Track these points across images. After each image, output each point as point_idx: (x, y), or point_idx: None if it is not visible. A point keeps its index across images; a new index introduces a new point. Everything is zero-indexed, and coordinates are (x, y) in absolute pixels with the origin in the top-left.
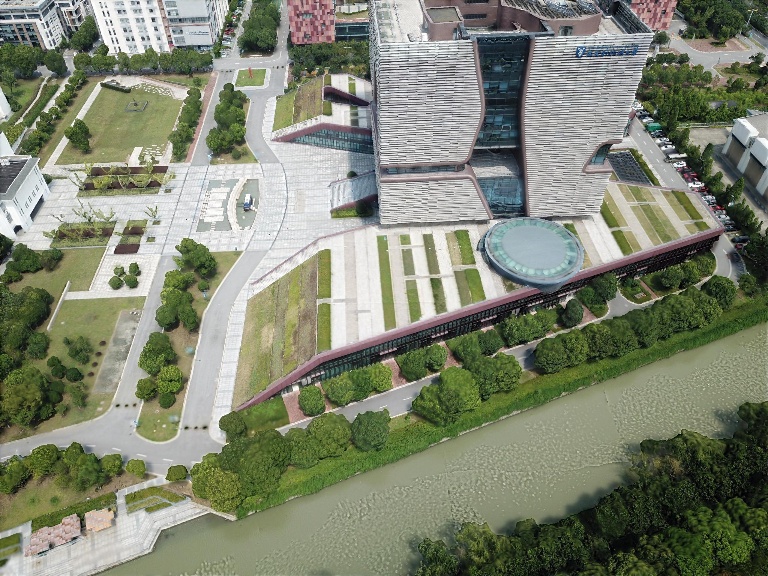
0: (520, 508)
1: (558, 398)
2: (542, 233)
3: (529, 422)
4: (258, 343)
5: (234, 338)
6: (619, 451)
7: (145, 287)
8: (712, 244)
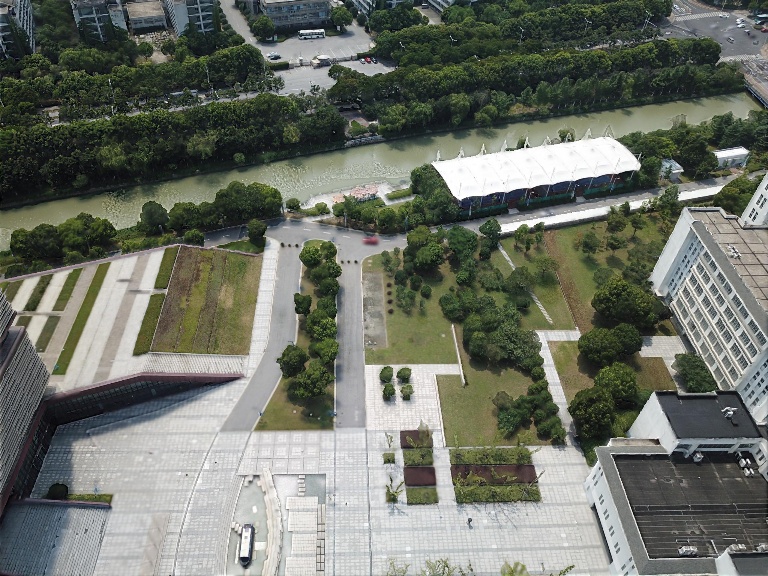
0: None
1: None
2: None
3: None
4: (237, 295)
5: (263, 313)
6: None
7: (371, 377)
8: None
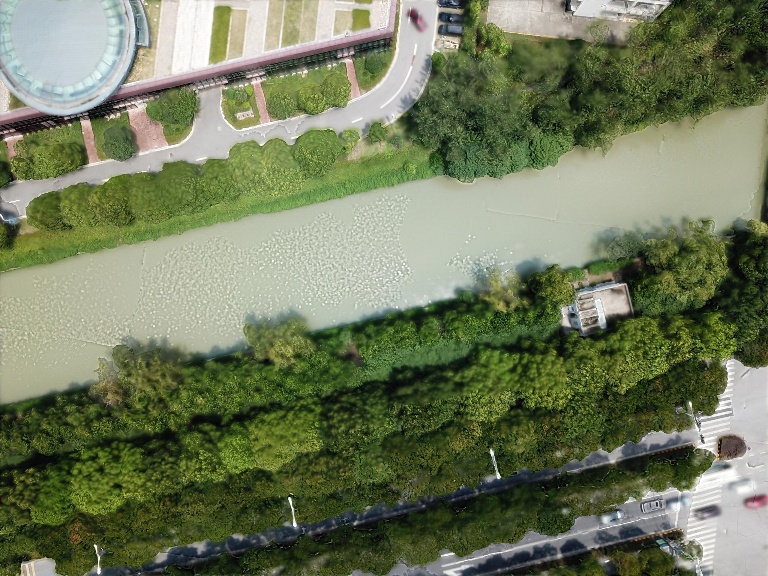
0: (4, 368)
1: (77, 254)
2: (81, 5)
3: (39, 276)
4: None
5: None
6: (117, 334)
7: None
8: (384, 43)
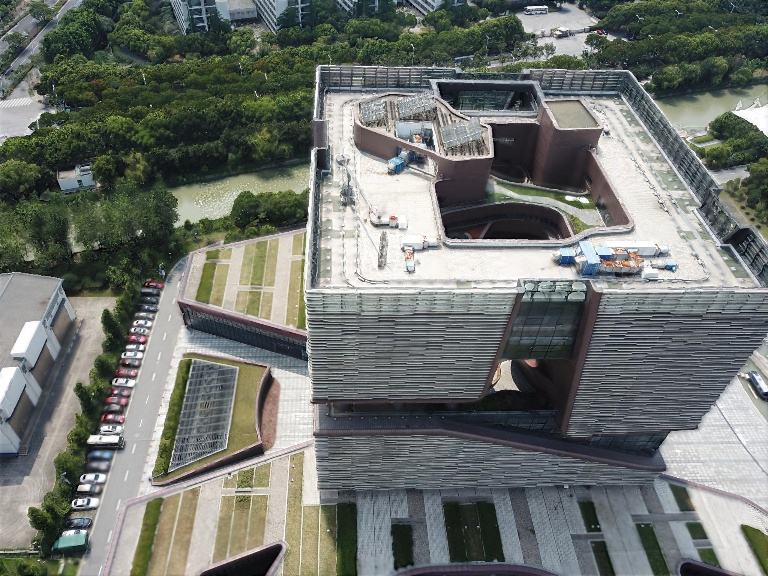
0: None
1: None
2: None
3: None
4: None
5: None
6: None
7: None
8: None
